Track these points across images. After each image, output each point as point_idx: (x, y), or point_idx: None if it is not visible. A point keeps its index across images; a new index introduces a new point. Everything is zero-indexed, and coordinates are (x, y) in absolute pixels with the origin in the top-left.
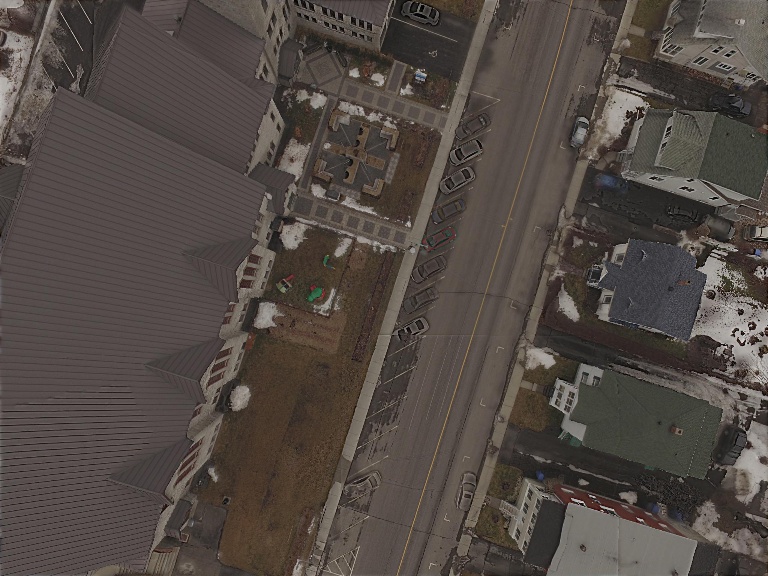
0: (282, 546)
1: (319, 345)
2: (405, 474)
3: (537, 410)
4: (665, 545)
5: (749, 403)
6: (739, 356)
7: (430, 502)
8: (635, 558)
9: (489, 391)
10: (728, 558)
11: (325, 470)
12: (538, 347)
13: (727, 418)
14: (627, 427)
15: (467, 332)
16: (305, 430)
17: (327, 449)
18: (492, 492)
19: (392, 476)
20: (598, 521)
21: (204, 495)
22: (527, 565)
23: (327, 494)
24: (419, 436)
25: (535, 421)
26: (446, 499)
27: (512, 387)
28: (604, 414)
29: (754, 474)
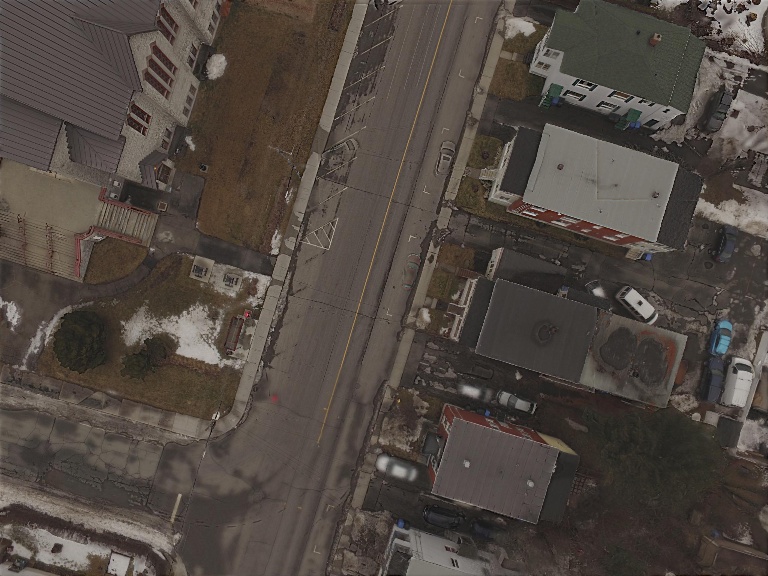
0: (260, 215)
1: (295, 12)
2: (383, 145)
3: (517, 78)
4: (645, 167)
5: (736, 71)
6: (725, 24)
7: (409, 173)
8: (614, 181)
9: (468, 62)
10: (715, 229)
11: (302, 140)
12: (518, 17)
13: (713, 87)
14: (605, 44)
15: (445, 1)
16: (282, 99)
17: (304, 118)
18: (472, 163)
19: (370, 147)
20: (576, 141)
21: (182, 163)
22: (508, 236)
23: (305, 164)
24: (397, 106)
25: (515, 90)
26: (425, 171)
27: (491, 57)
28: (581, 35)
29: (741, 142)
